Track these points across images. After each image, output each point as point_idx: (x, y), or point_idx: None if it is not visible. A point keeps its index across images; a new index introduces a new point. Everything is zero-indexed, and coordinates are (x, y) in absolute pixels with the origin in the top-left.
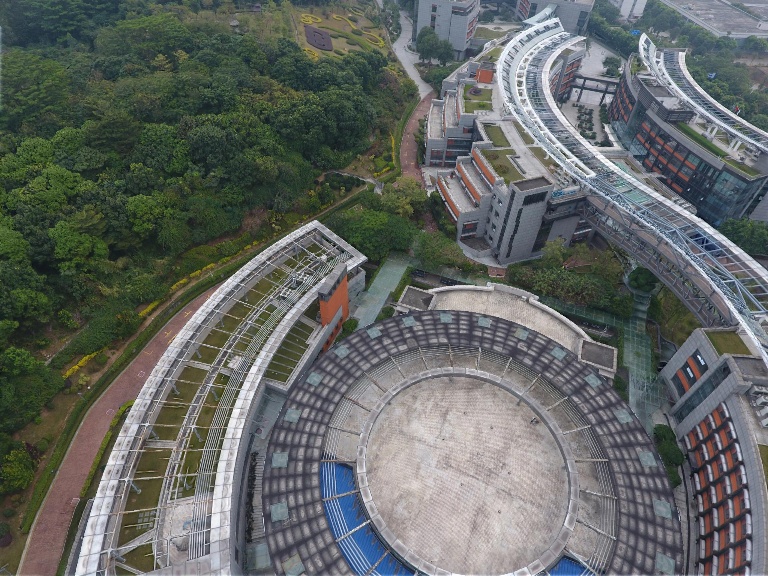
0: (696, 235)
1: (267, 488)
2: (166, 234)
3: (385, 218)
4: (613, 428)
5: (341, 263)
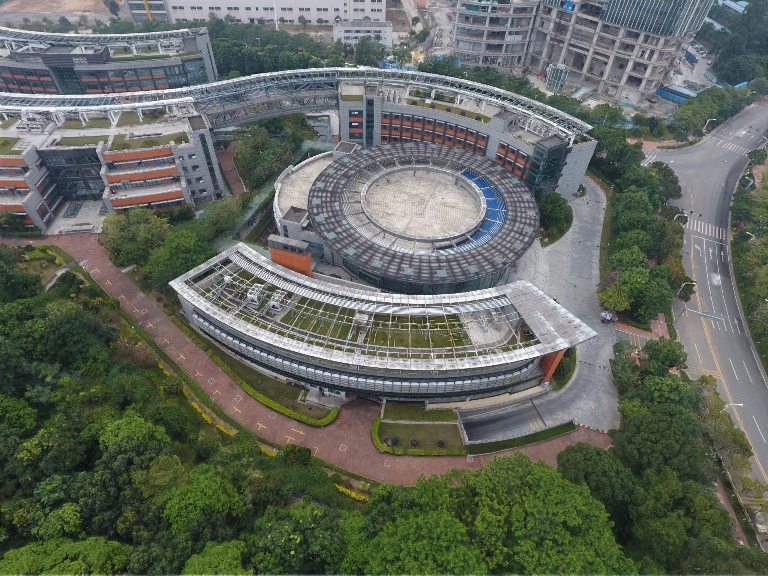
0: (272, 79)
1: (461, 277)
2: (174, 414)
3: (182, 231)
4: (394, 151)
5: (270, 237)
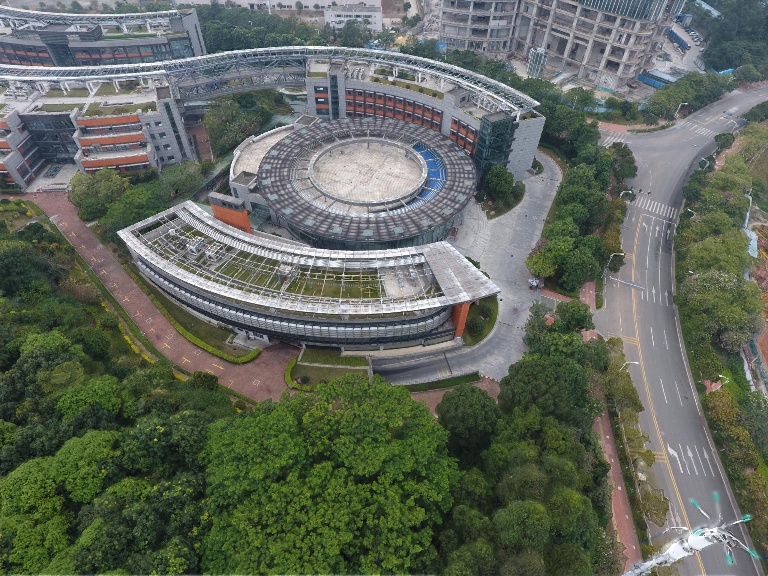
0: (243, 56)
1: (385, 237)
2: (95, 336)
3: (138, 189)
4: (352, 125)
5: (210, 194)
